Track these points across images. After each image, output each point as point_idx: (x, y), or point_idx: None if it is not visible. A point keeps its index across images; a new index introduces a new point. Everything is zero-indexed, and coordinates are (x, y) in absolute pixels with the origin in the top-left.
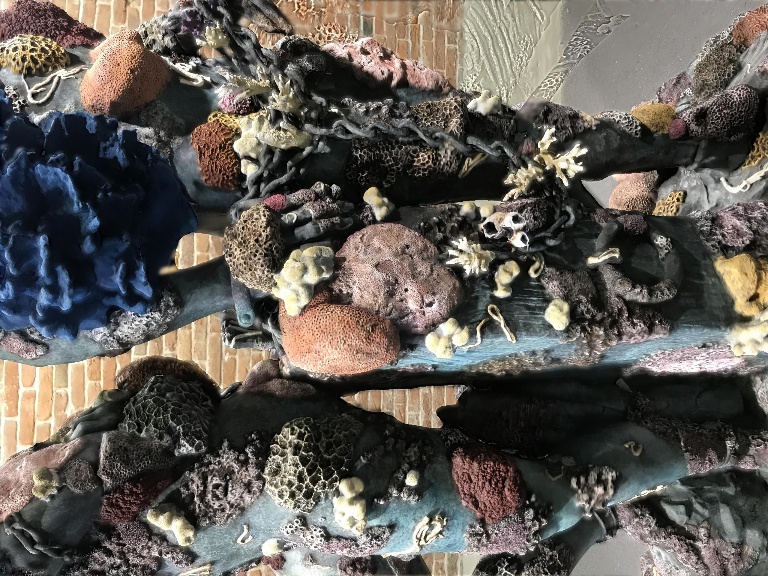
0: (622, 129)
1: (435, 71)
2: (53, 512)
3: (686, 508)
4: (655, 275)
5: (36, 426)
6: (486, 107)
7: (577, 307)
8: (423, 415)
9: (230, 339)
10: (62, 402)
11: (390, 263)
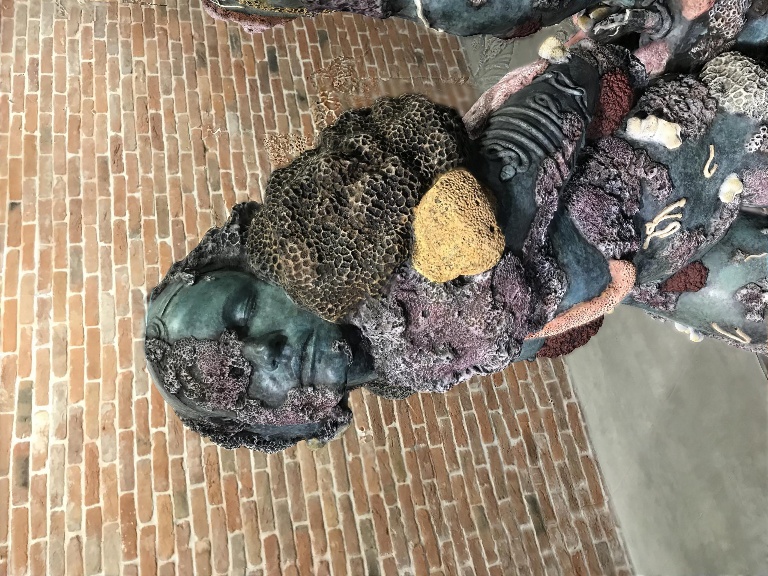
0: None
1: None
2: (576, 69)
3: None
4: None
5: (159, 567)
6: None
7: None
8: (566, 493)
9: (623, 12)
10: (184, 535)
11: None
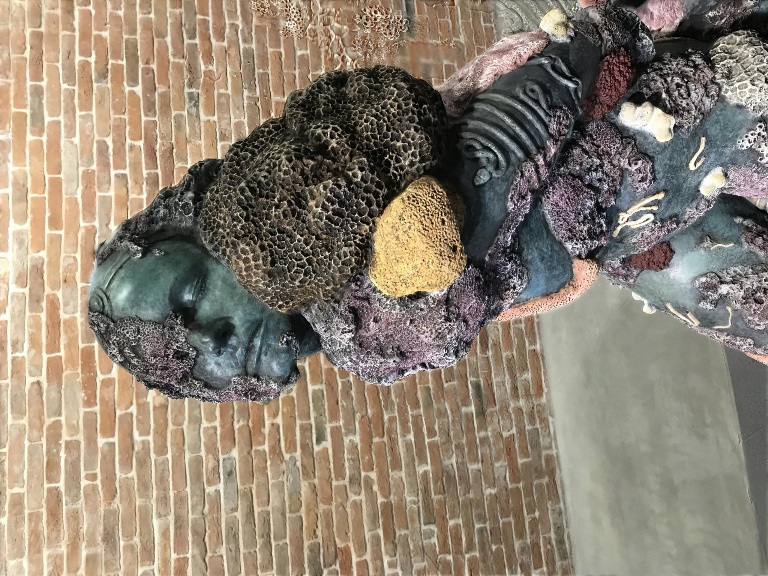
0: None
1: None
2: (577, 52)
3: None
4: None
5: (117, 416)
6: None
7: None
8: (509, 381)
9: None
10: (143, 389)
11: None
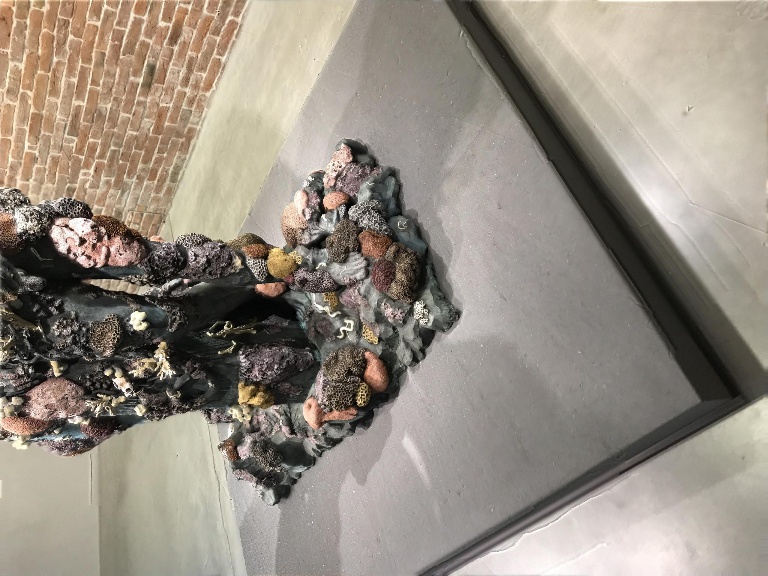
0: None
1: (132, 253)
2: None
3: None
4: (203, 390)
5: None
6: (137, 329)
7: None
8: (185, 72)
9: None
10: None
11: (54, 404)
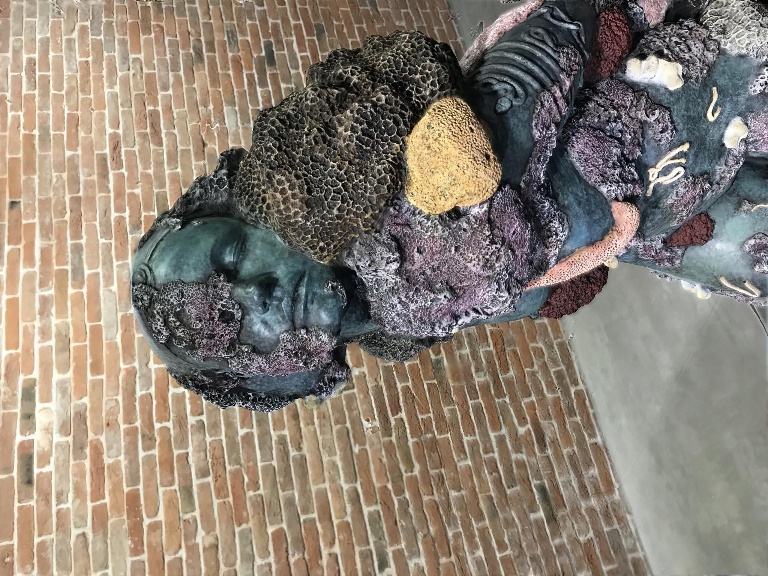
0: None
1: None
2: (573, 5)
3: None
4: None
5: (166, 562)
6: None
7: None
8: (575, 480)
9: None
10: (191, 529)
11: None
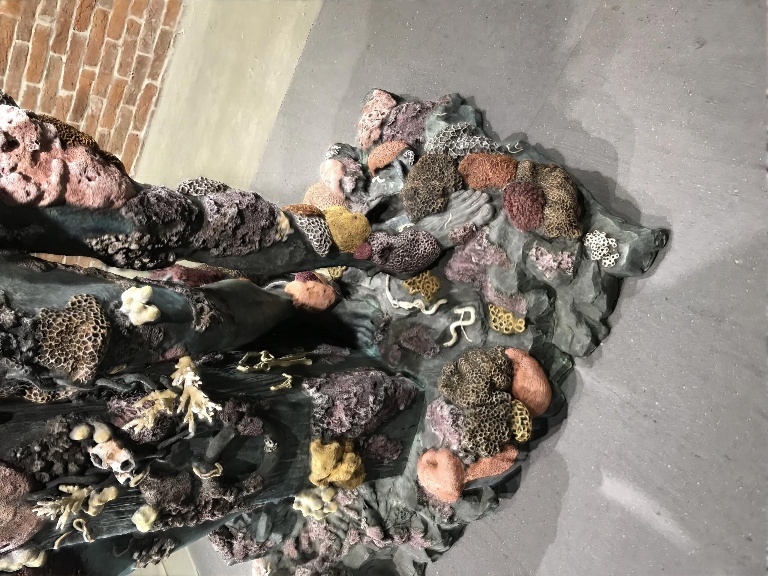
0: (312, 245)
1: (111, 179)
2: None
3: (235, 519)
4: (254, 462)
5: None
6: (139, 320)
7: (166, 507)
8: None
9: None
10: None
11: None
